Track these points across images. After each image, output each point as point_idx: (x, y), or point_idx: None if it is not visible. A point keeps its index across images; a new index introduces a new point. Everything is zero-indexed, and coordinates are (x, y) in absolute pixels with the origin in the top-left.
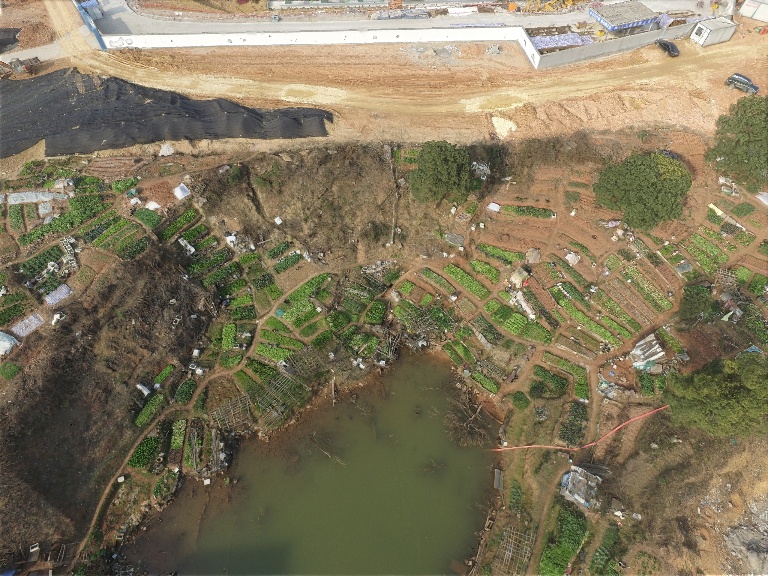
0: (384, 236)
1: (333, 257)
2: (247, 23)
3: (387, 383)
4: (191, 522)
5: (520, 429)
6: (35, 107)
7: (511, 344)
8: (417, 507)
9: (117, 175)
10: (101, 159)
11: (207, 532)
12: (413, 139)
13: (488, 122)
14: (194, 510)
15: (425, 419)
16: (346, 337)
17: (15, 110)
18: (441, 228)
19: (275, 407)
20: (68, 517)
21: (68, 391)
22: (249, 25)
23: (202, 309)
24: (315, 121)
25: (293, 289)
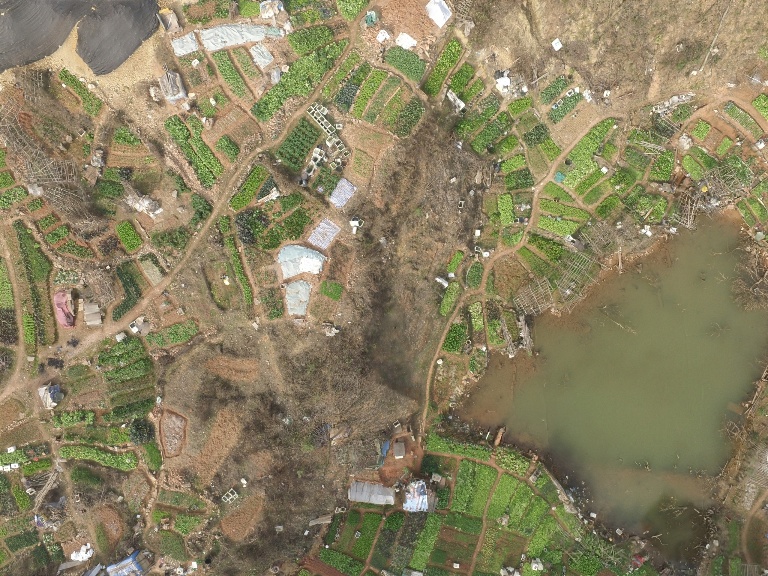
0: (694, 61)
1: (619, 94)
2: None
3: (672, 249)
4: (505, 387)
5: None
6: None
7: None
8: (702, 365)
9: None
10: None
11: (520, 394)
12: None
13: None
14: (505, 378)
15: (712, 285)
16: (633, 201)
17: None
18: (767, 42)
19: (575, 289)
20: (413, 399)
21: (385, 298)
22: None
23: (479, 183)
24: None
25: (572, 144)
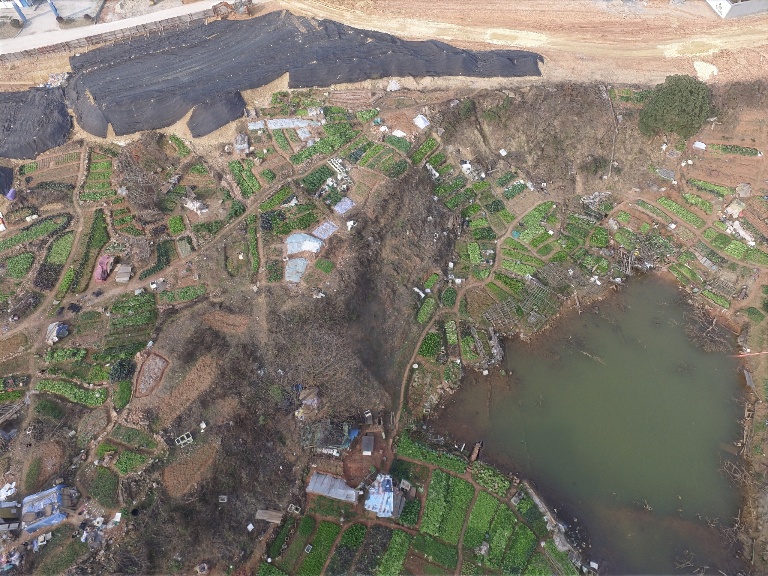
0: (602, 169)
1: (554, 187)
2: None
3: (622, 298)
4: (480, 404)
5: (760, 338)
6: (266, 44)
7: (736, 267)
8: (678, 399)
9: (358, 106)
10: (339, 92)
11: (496, 412)
12: (622, 80)
13: (690, 66)
14: (480, 395)
15: (666, 329)
16: (579, 257)
17: (249, 46)
18: (652, 163)
19: (538, 311)
20: (387, 392)
21: (369, 287)
22: None
23: (451, 227)
24: (529, 61)
25: (523, 214)
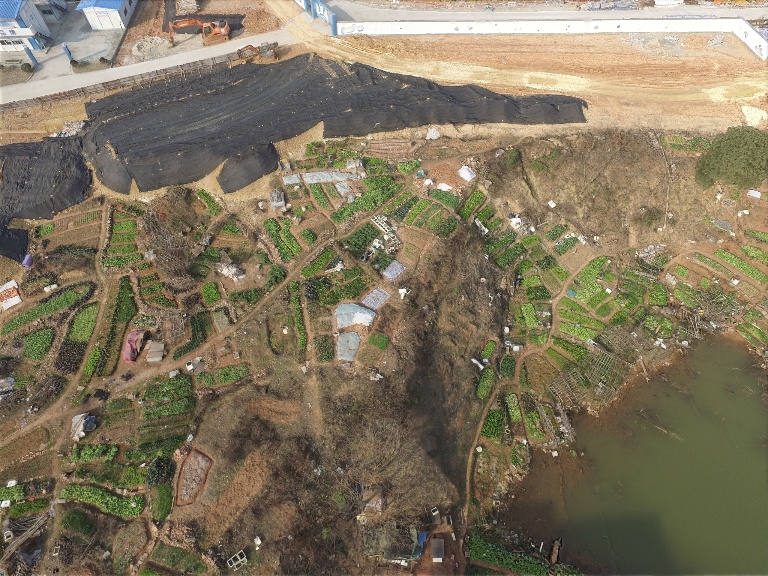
0: (657, 220)
1: (606, 240)
2: (463, 12)
3: (690, 363)
4: (553, 491)
5: None
6: (296, 90)
7: None
8: (767, 481)
9: (398, 157)
10: (377, 141)
11: (571, 501)
12: (670, 126)
13: (739, 111)
14: (552, 480)
15: (742, 398)
16: (640, 318)
17: (278, 93)
18: (707, 214)
19: (606, 383)
20: (453, 483)
21: (426, 363)
22: (466, 14)
23: None
24: (574, 107)
25: (577, 271)
